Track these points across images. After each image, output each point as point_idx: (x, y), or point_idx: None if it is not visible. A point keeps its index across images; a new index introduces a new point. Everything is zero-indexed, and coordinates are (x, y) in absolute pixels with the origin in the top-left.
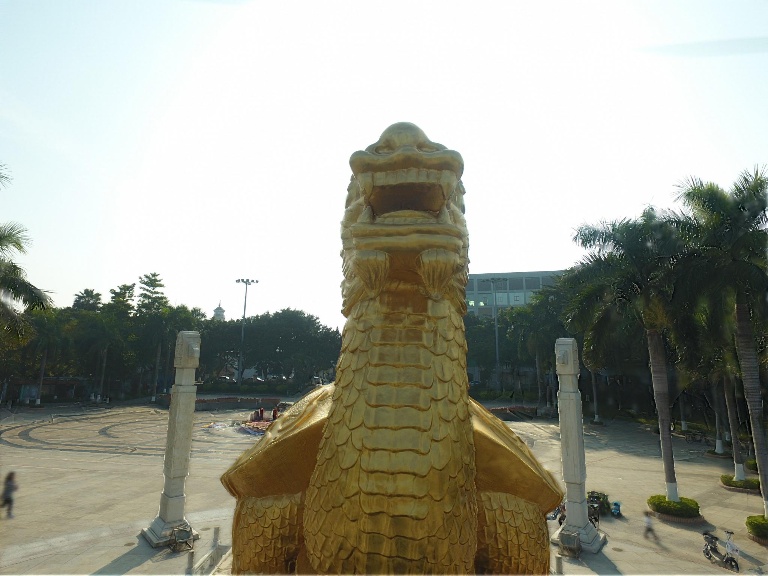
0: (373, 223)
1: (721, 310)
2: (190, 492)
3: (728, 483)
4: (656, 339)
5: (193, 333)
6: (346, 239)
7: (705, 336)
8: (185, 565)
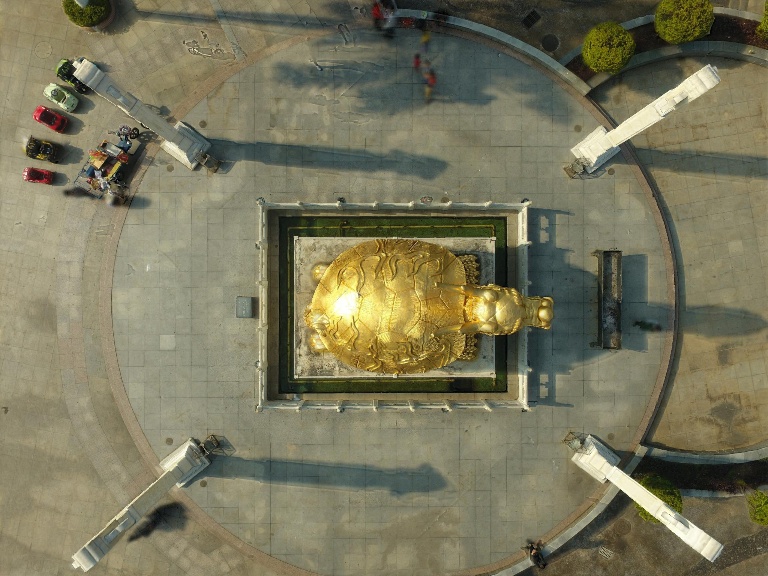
0: None
1: None
2: (28, 509)
3: None
4: None
5: (90, 553)
6: None
7: None
8: (241, 428)
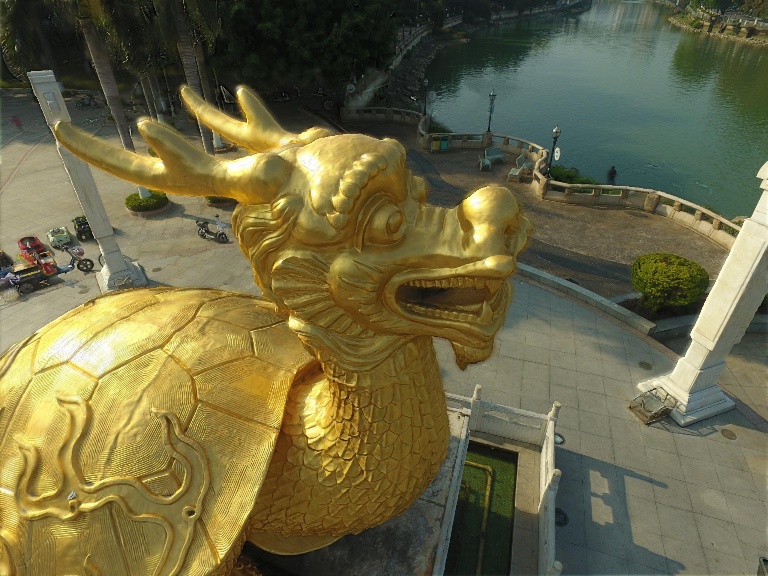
0: (495, 319)
1: (170, 7)
2: None
3: (156, 155)
4: (94, 33)
5: None
6: (370, 304)
7: (148, 31)
8: None
